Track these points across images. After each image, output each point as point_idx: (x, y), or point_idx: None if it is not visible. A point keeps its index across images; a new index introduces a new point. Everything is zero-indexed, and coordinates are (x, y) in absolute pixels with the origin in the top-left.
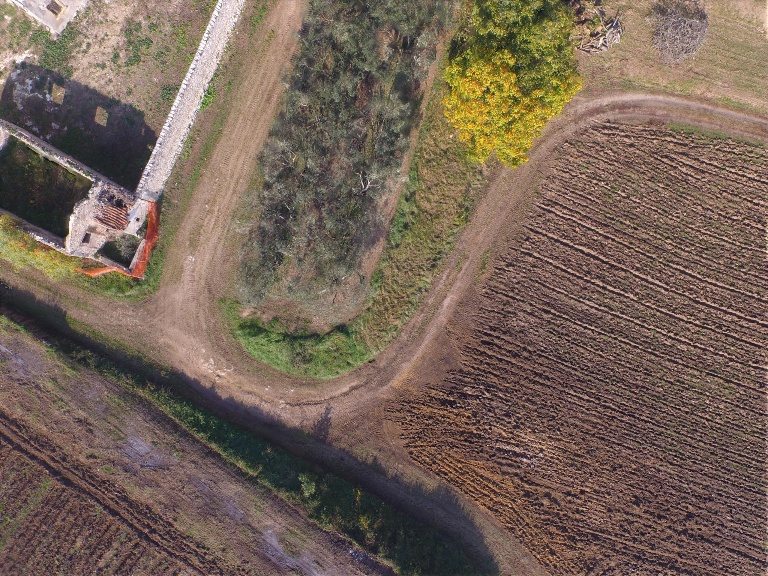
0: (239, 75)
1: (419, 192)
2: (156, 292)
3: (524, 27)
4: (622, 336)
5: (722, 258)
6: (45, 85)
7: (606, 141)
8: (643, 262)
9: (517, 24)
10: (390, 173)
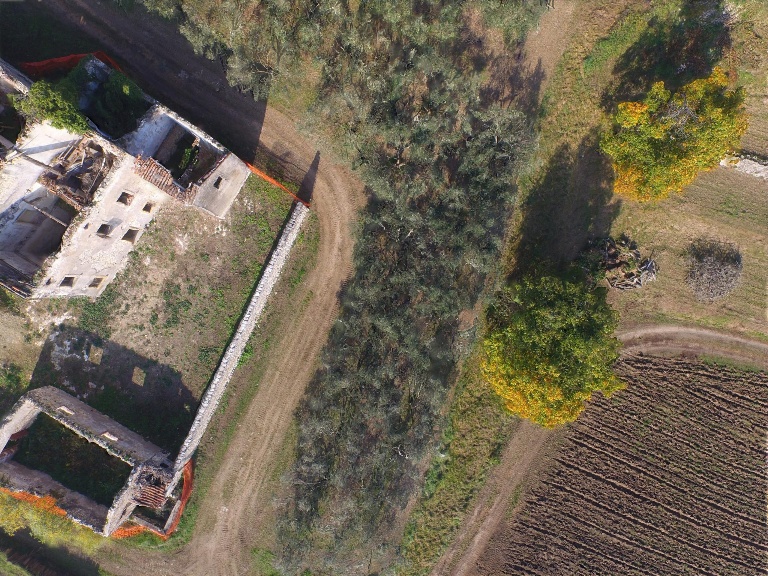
0: (277, 333)
1: (454, 441)
2: (189, 542)
3: (568, 333)
4: (653, 570)
5: (754, 492)
6: (83, 346)
7: (639, 375)
8: (675, 495)
9: (561, 330)
10: (429, 450)
